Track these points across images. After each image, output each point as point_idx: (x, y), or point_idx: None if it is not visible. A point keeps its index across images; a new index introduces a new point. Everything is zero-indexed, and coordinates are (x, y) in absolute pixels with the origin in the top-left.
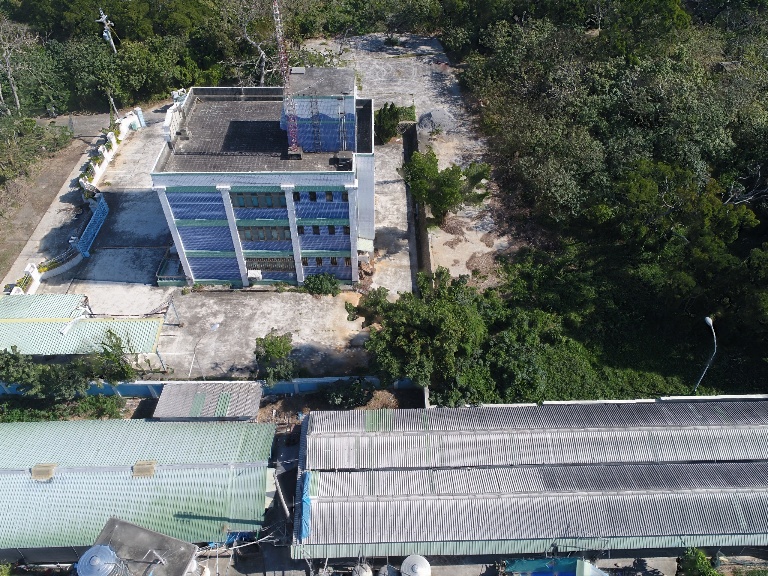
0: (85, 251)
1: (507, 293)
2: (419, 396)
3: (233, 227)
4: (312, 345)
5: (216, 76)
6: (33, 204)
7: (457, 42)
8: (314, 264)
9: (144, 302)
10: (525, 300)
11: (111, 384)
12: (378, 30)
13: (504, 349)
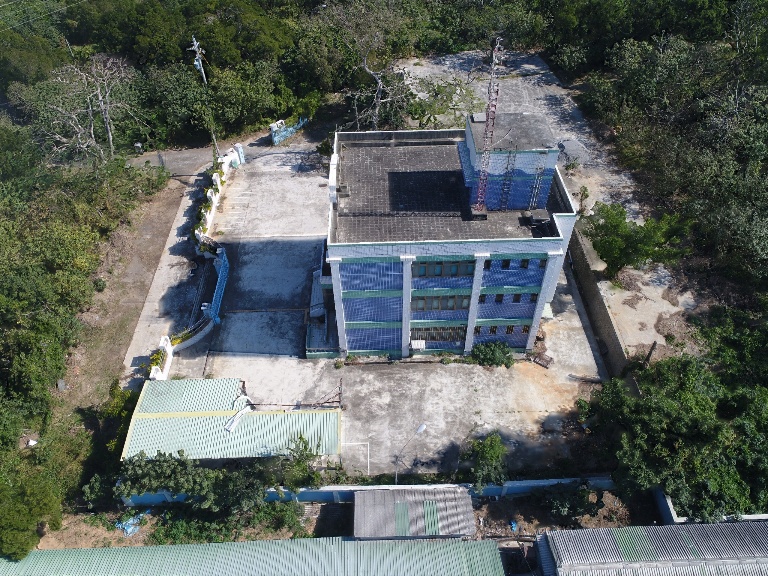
0: (215, 316)
1: (715, 365)
2: (649, 499)
3: (407, 298)
4: (500, 431)
5: (315, 105)
6: (141, 258)
7: (572, 62)
8: (487, 332)
9: (295, 379)
10: (741, 374)
11: (292, 491)
12: (473, 47)
13: (747, 443)
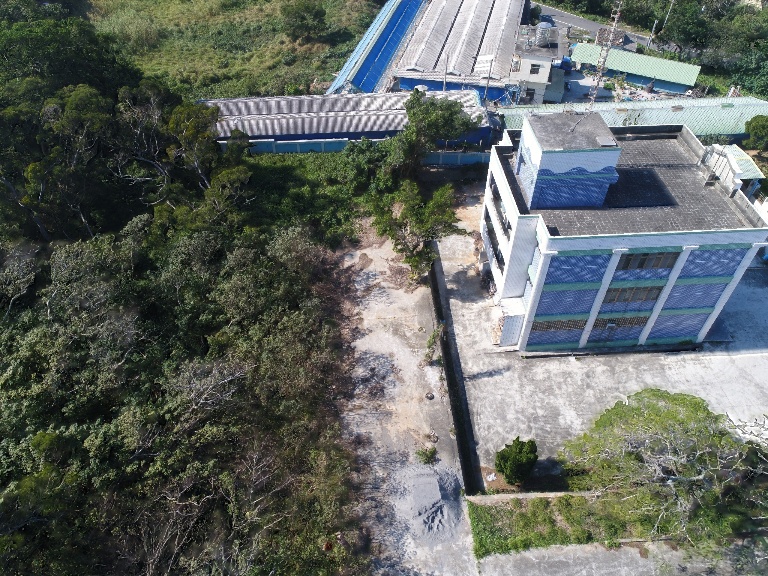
0: None
1: None
2: None
3: None
4: None
5: None
6: None
7: None
8: None
9: None
10: None
11: None
12: None
13: None
